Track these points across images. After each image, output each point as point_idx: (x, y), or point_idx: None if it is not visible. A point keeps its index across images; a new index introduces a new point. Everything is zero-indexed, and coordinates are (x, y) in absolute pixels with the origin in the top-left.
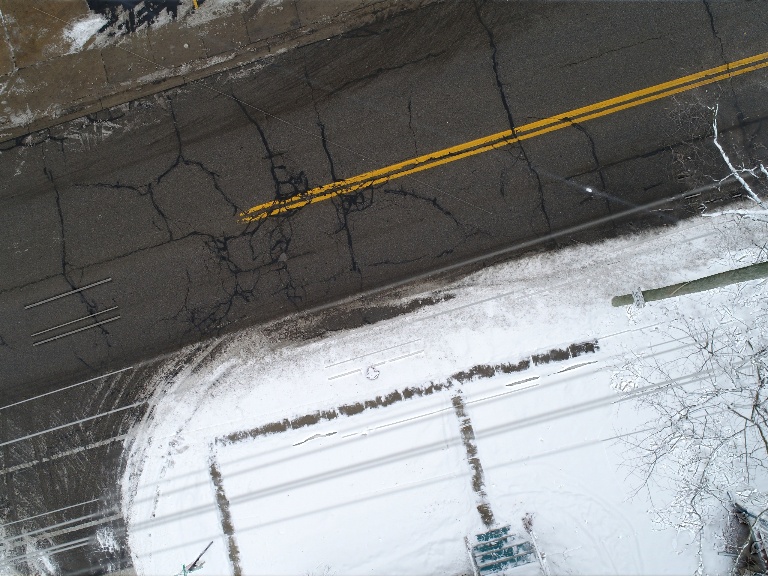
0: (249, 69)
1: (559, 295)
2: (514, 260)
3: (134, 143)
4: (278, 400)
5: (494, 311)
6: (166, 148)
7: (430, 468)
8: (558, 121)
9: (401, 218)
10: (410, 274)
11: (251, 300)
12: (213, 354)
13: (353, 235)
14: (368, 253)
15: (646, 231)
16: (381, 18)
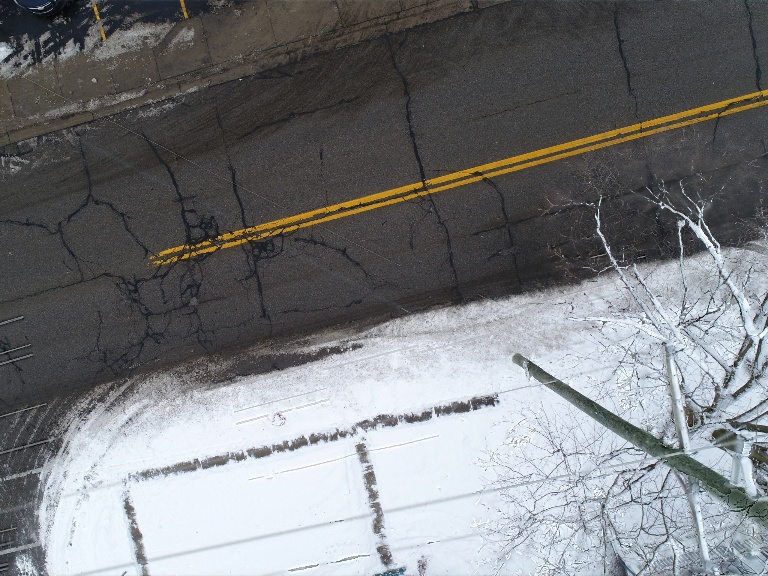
0: (159, 107)
1: (462, 350)
2: (421, 313)
3: (43, 180)
4: (188, 442)
5: (399, 363)
6: (76, 186)
7: (332, 512)
8: (469, 175)
9: (311, 267)
10: (319, 323)
11: (162, 343)
12: (125, 394)
13: (263, 282)
14: (278, 301)
15: (551, 289)
16: (294, 59)
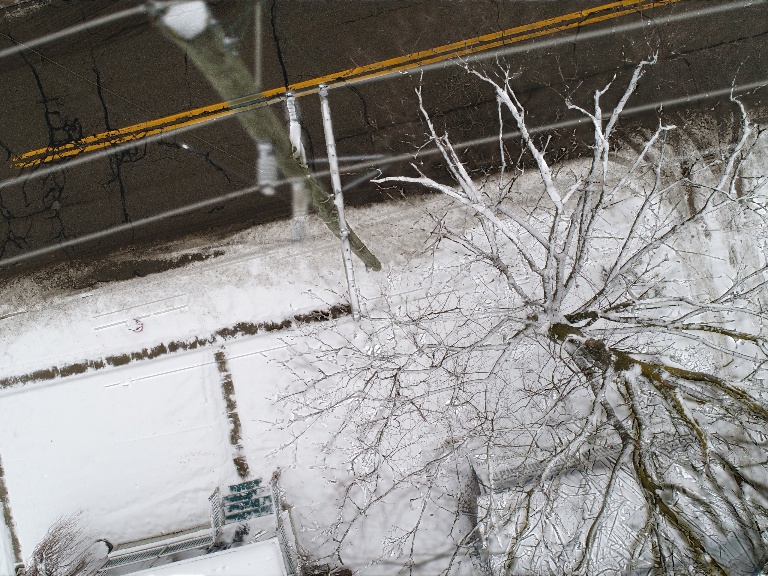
0: (26, 8)
1: (322, 257)
2: (283, 220)
3: None
4: (45, 348)
5: (259, 270)
6: None
7: (187, 420)
8: (332, 80)
9: (173, 172)
10: (181, 229)
11: (24, 247)
12: None
13: (126, 186)
14: (140, 205)
15: (413, 197)
16: None
